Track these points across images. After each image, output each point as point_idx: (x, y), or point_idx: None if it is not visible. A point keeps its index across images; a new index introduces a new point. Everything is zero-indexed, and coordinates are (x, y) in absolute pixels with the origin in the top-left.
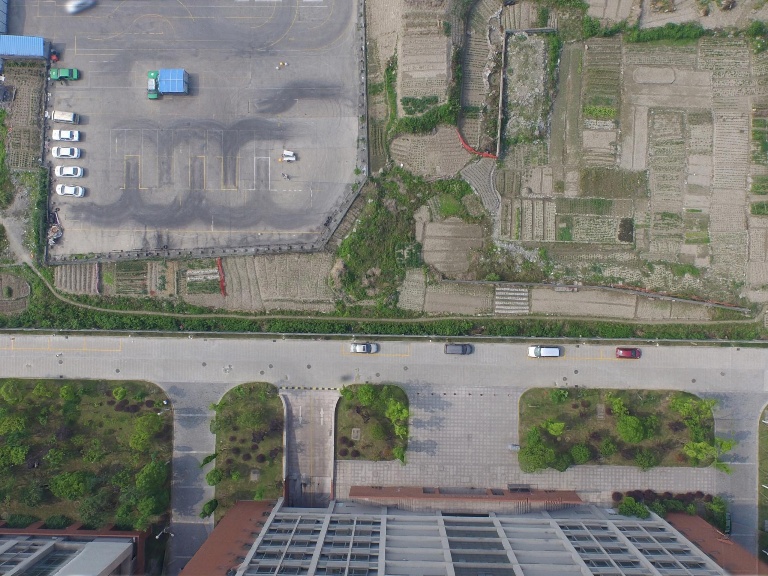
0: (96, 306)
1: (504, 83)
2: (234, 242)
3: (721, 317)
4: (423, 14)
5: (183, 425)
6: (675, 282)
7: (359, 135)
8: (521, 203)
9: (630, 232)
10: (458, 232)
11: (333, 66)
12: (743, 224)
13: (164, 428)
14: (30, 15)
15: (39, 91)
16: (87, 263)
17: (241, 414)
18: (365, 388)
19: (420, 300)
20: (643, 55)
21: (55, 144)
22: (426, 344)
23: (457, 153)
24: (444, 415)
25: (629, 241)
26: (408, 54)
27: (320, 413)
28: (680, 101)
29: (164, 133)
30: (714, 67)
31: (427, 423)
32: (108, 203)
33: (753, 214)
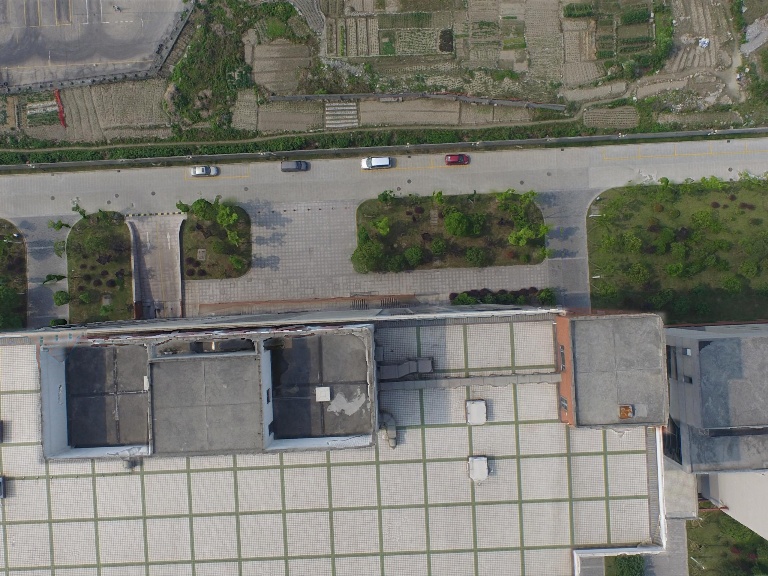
0: None
1: None
2: (71, 75)
3: (541, 116)
4: None
5: (36, 258)
6: (495, 86)
7: None
8: (345, 22)
9: (450, 42)
10: (286, 52)
11: None
12: (557, 28)
13: (16, 260)
14: None
15: None
16: None
17: None
18: (199, 200)
19: (253, 119)
20: None
21: None
22: (264, 164)
23: None
24: (285, 231)
25: (450, 51)
26: None
27: (167, 238)
28: None
29: None
30: None
31: (269, 240)
32: None
33: (566, 17)
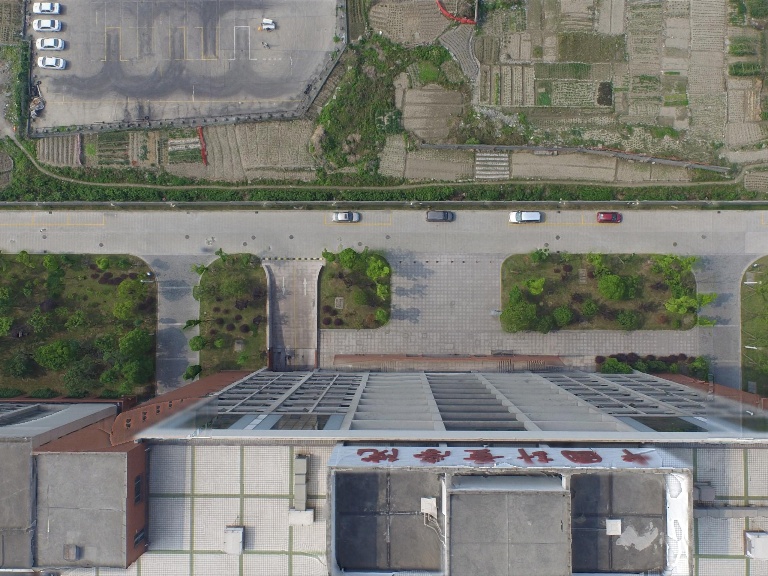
0: (79, 179)
1: None
2: (215, 112)
3: (701, 178)
4: None
5: (167, 297)
6: (654, 144)
7: (338, 3)
8: (500, 69)
9: (609, 96)
10: (438, 98)
11: None
12: (721, 86)
13: (148, 299)
14: None
15: None
16: (69, 135)
17: None
18: (346, 249)
19: (401, 166)
20: None
21: (36, 18)
22: (408, 212)
23: (435, 19)
24: (427, 283)
25: (608, 105)
26: None
27: (303, 283)
28: None
29: (144, 5)
30: None
31: (410, 291)
32: (89, 75)
33: (731, 75)
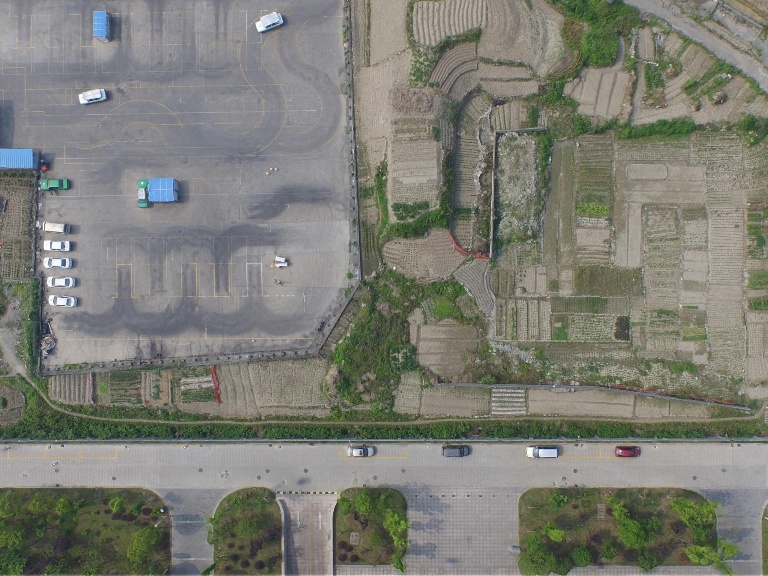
0: (91, 415)
1: (495, 184)
2: (228, 349)
3: (720, 415)
4: (412, 120)
5: (181, 532)
6: (673, 380)
7: (351, 239)
8: (516, 303)
9: (626, 330)
10: (453, 334)
11: (323, 170)
12: (740, 320)
13: (162, 536)
14: (19, 125)
15: (29, 201)
16: (81, 373)
17: (239, 520)
18: (362, 497)
19: (416, 403)
20: (635, 151)
21: (47, 254)
22: (423, 446)
23: (450, 255)
24: (443, 517)
25: (625, 339)
26: (398, 160)
27: (318, 517)
28: (674, 197)
29: (155, 241)
30: (707, 162)
31: (426, 526)
32: (101, 312)
33: (750, 309)
